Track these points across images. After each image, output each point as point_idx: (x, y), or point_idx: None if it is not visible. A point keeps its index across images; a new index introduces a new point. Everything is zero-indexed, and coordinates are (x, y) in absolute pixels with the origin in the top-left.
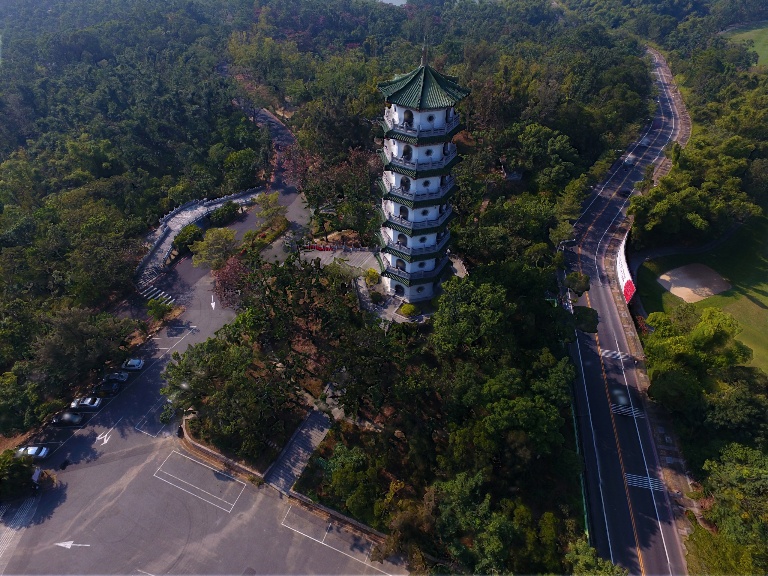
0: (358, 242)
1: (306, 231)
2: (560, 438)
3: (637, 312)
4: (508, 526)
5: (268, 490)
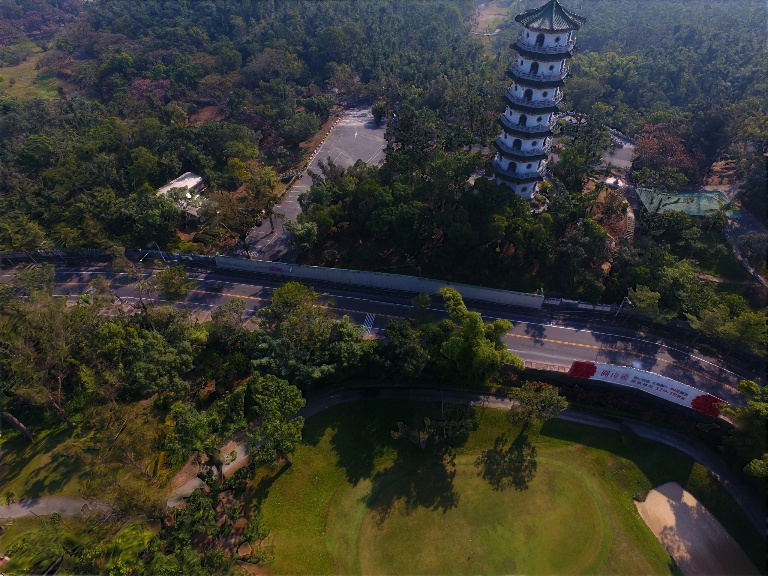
0: None
1: None
2: (374, 228)
3: (565, 390)
4: (324, 194)
5: None
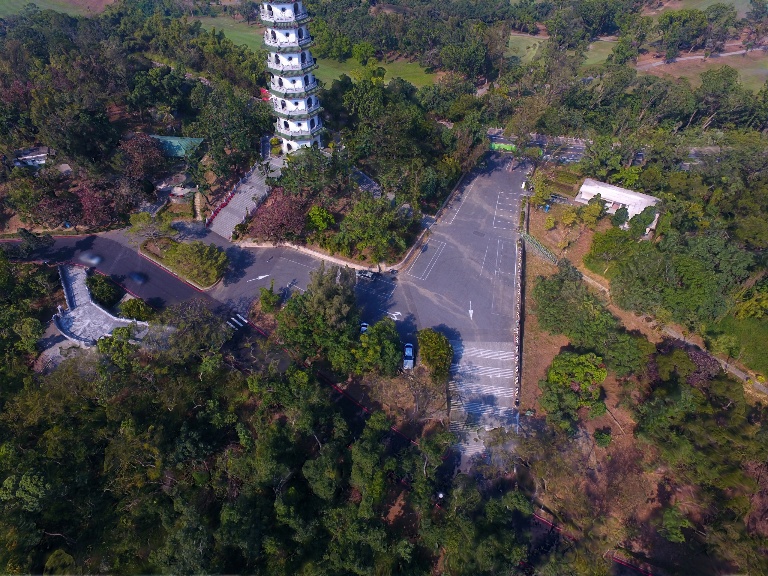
0: (231, 180)
1: (178, 225)
2: None
3: None
4: None
5: (433, 230)
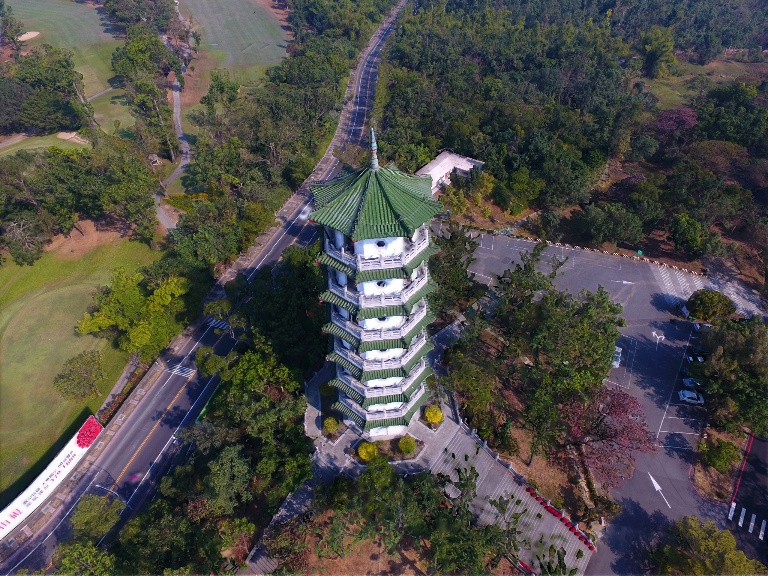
0: None
1: None
2: None
3: None
4: None
5: None
